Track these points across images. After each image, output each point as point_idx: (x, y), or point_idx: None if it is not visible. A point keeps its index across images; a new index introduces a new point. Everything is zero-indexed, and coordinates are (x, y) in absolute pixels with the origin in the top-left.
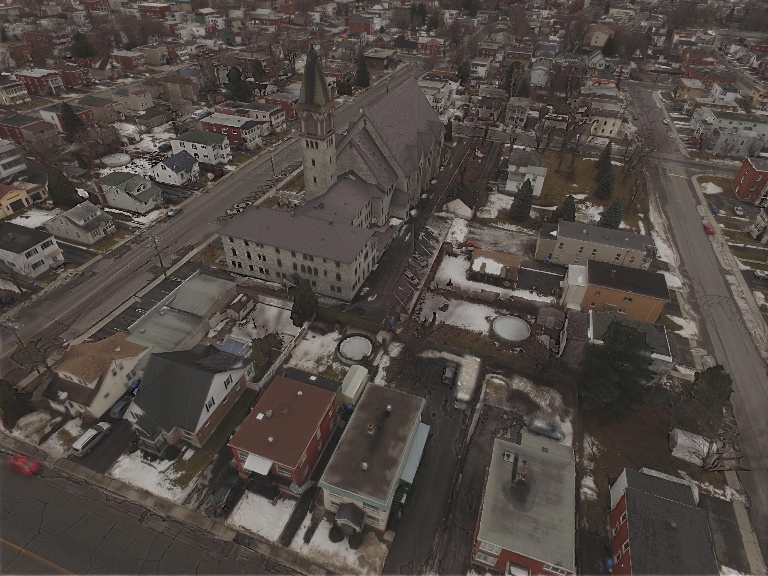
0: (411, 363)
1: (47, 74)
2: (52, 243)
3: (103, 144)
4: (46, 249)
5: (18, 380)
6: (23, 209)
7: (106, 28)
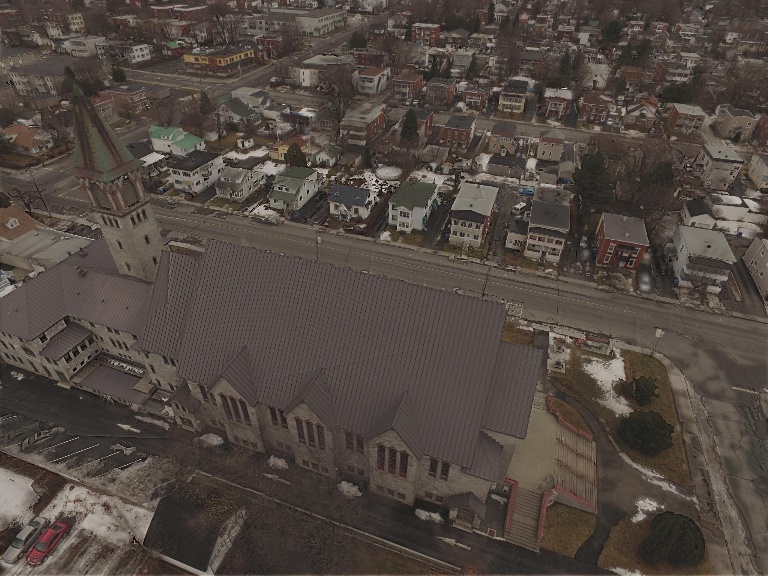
0: None
1: (555, 97)
2: (190, 176)
3: (419, 159)
4: (186, 177)
5: (53, 211)
6: None
7: (746, 79)
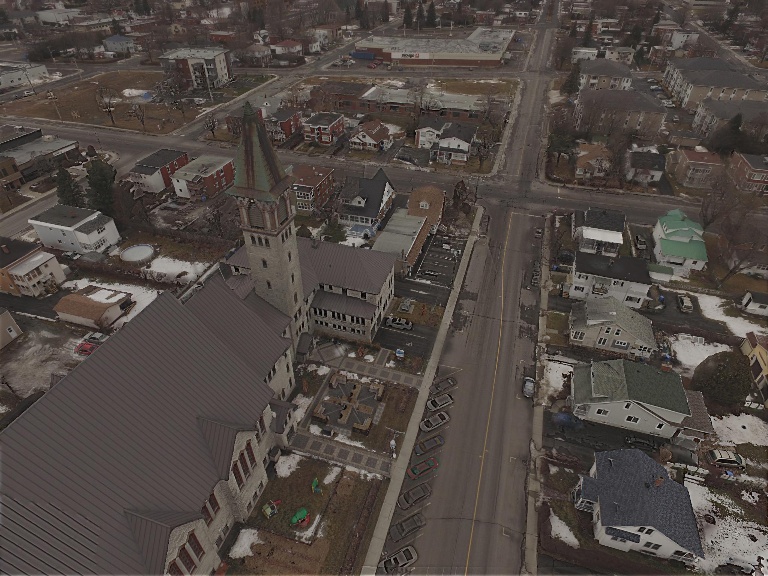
0: (232, 234)
1: None
2: None
3: None
4: None
5: None
6: (750, 375)
7: None
